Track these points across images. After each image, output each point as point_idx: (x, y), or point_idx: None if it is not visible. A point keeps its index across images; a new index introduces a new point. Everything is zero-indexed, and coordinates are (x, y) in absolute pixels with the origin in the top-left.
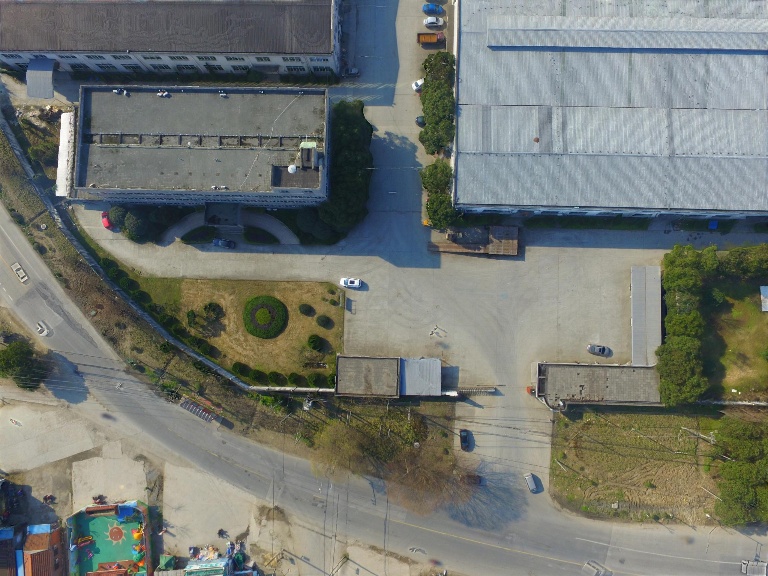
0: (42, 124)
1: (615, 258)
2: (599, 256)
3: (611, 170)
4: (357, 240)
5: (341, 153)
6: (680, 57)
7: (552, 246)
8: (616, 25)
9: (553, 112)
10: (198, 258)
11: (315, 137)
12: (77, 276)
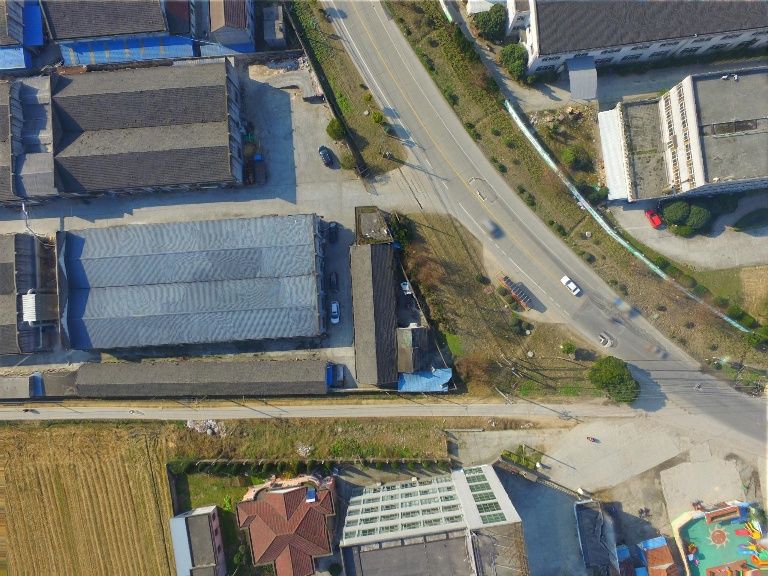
0: (561, 128)
1: None
2: None
3: None
4: None
5: None
6: None
7: None
8: None
9: None
10: (752, 244)
11: None
12: (635, 280)
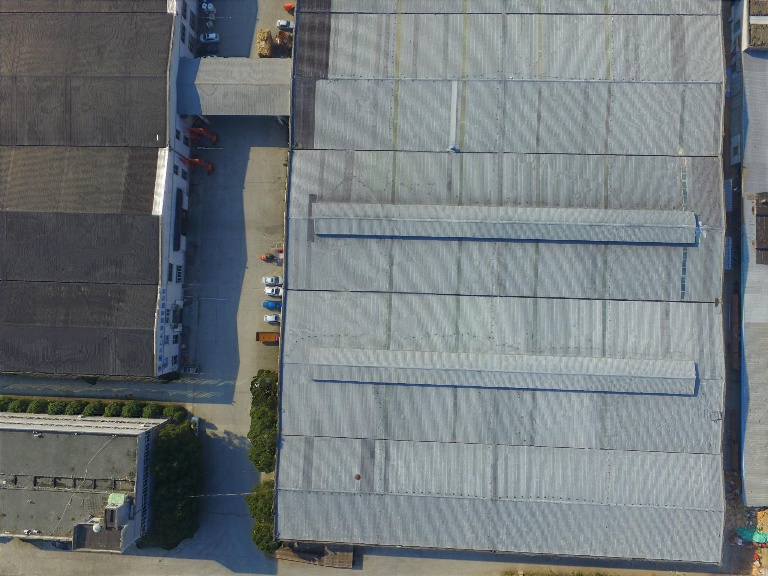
0: None
1: (454, 569)
2: (438, 567)
3: (433, 511)
4: (195, 543)
5: (158, 491)
6: (506, 393)
7: (390, 555)
8: (439, 362)
9: (376, 446)
10: (37, 556)
11: (129, 480)
12: None
